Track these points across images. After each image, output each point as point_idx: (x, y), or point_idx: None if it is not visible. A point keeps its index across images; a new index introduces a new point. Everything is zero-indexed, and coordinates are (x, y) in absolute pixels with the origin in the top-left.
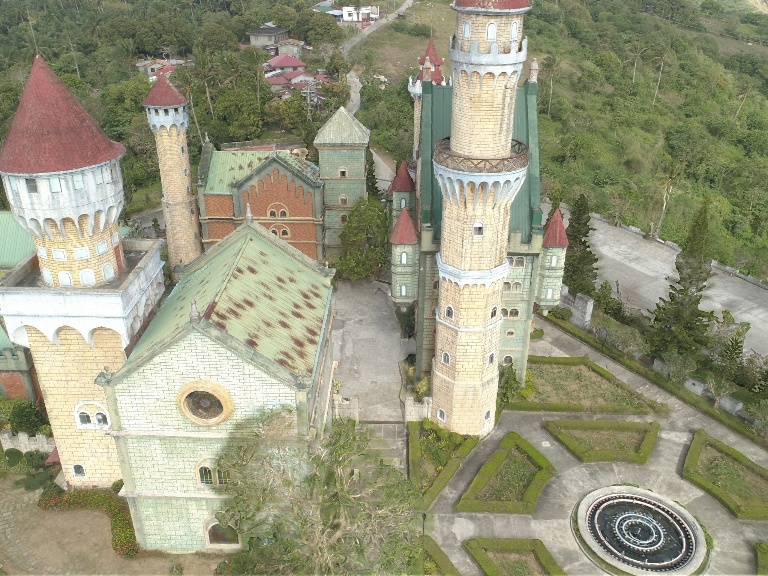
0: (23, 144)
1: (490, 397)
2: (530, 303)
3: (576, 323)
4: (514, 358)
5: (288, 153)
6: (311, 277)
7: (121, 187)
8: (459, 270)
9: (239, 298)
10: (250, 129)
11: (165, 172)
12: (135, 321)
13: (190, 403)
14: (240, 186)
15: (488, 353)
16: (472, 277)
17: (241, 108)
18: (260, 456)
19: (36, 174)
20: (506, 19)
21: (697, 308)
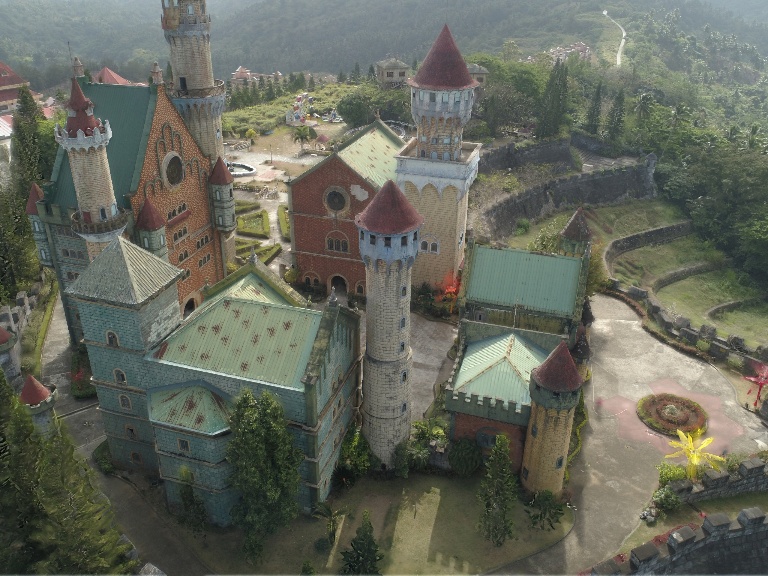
0: None
1: None
2: None
3: None
4: None
5: (216, 303)
6: None
7: None
8: None
9: None
10: None
11: None
12: None
13: None
14: None
15: None
16: None
17: None
18: None
19: None
20: None
21: None
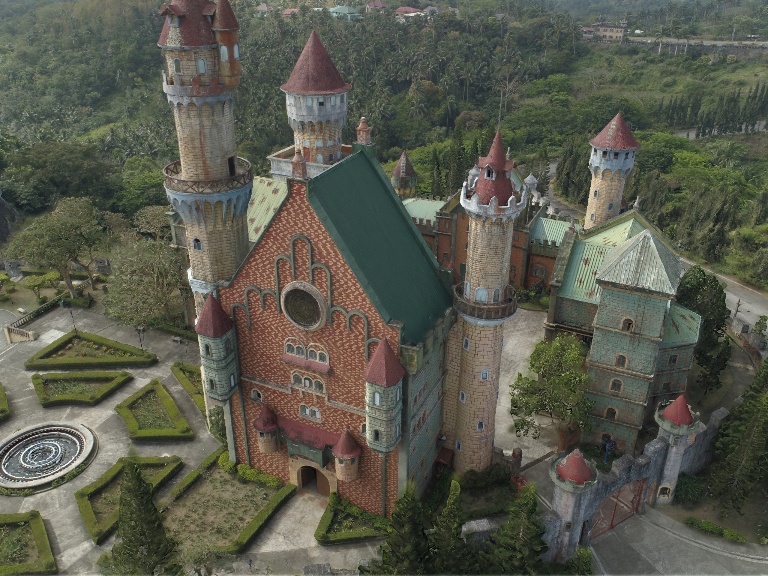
0: None
1: None
2: None
3: None
4: None
5: None
6: None
7: (305, 114)
8: None
9: None
10: None
11: None
12: None
13: None
14: None
15: None
16: None
17: None
18: None
19: None
20: None
21: None
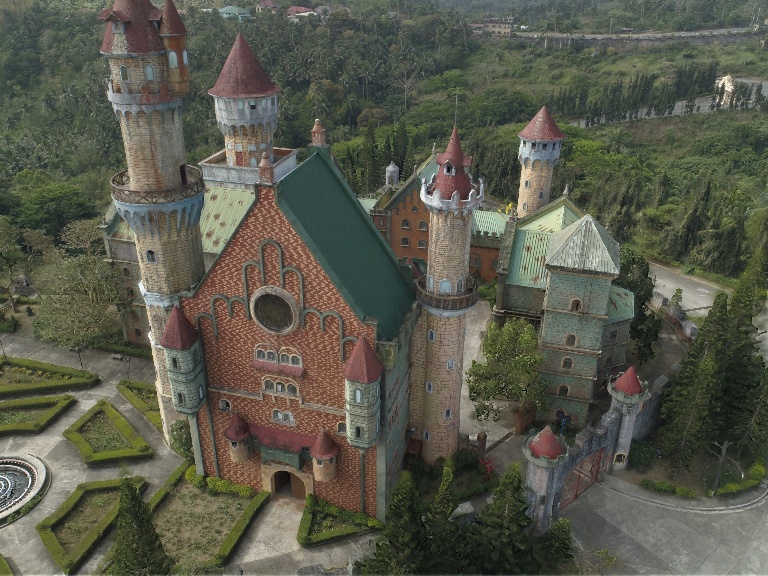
0: None
1: None
2: None
3: None
4: None
5: None
6: None
7: (237, 118)
8: None
9: None
10: None
11: None
12: None
13: None
14: None
15: None
16: None
17: None
18: None
19: None
20: None
21: None
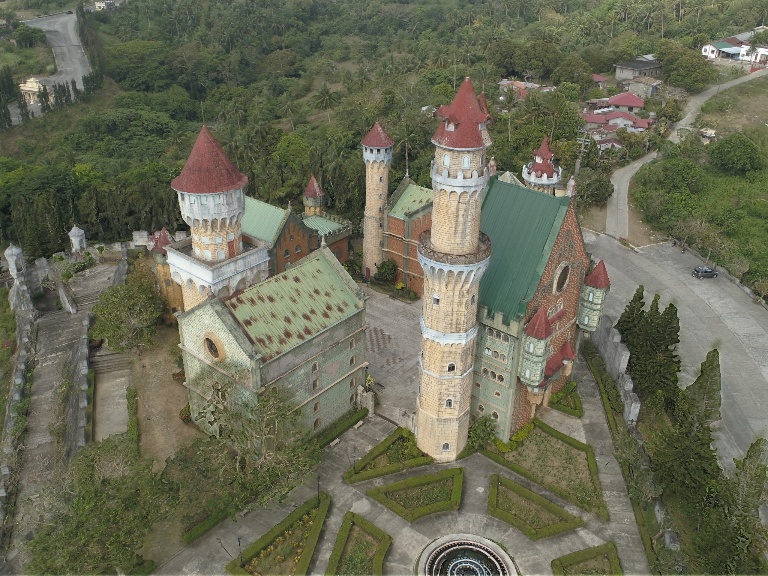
0: (184, 173)
1: (449, 433)
2: (512, 375)
3: (625, 419)
4: (500, 415)
5: None
6: (349, 297)
7: (236, 207)
8: (425, 326)
9: (266, 294)
10: None
11: (367, 193)
12: (230, 289)
13: (209, 344)
14: (411, 216)
15: (445, 397)
16: (431, 334)
17: (529, 142)
18: (238, 392)
19: (182, 192)
20: (457, 153)
21: (705, 446)
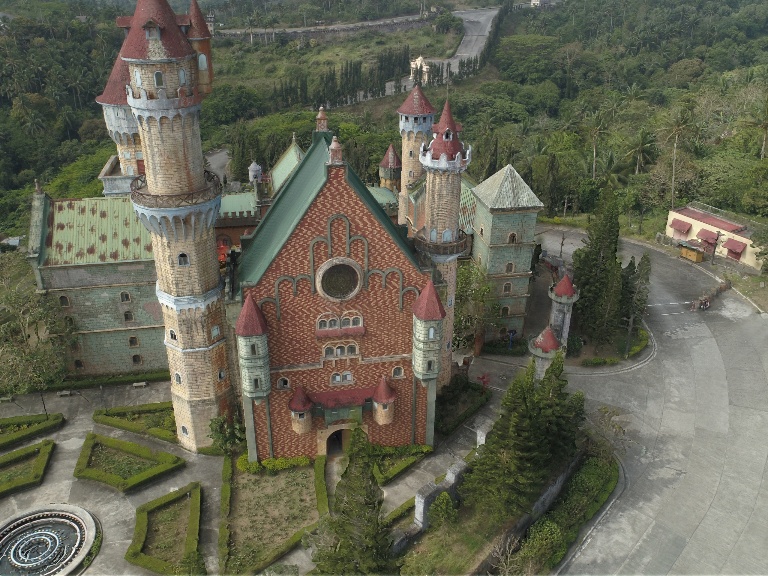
0: None
1: None
2: None
3: None
4: None
5: None
6: None
7: None
8: None
9: (103, 208)
10: (760, 202)
11: None
12: None
13: None
14: None
15: None
16: None
17: None
18: None
19: None
20: None
21: None
